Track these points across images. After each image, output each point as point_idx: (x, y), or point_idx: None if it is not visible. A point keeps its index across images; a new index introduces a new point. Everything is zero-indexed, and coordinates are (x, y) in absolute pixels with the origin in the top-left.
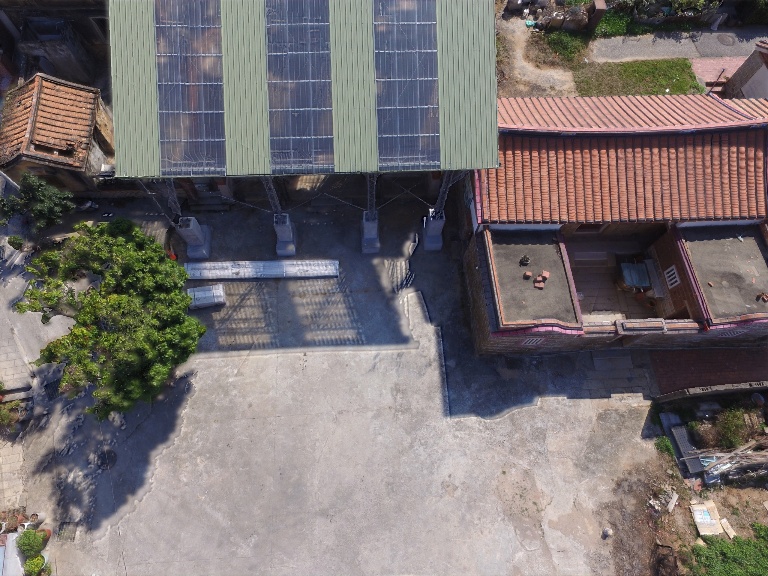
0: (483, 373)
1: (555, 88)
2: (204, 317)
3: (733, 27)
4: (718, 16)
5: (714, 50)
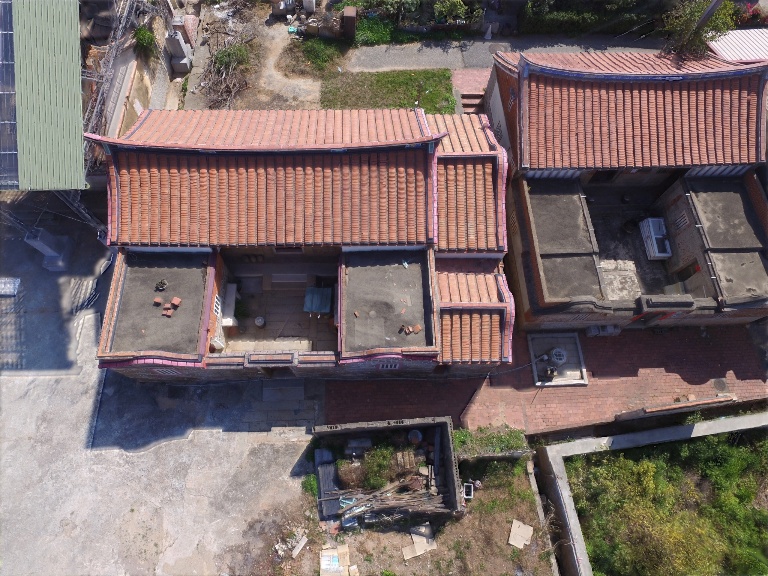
0: (140, 402)
1: (297, 99)
2: None
3: (509, 36)
4: (489, 25)
5: (481, 60)
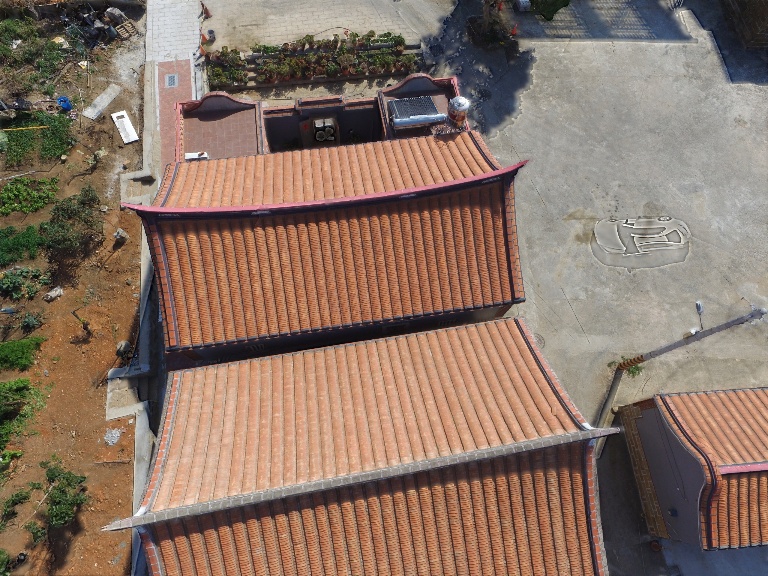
0: (751, 59)
1: None
2: (530, 17)
3: None
4: None
5: None
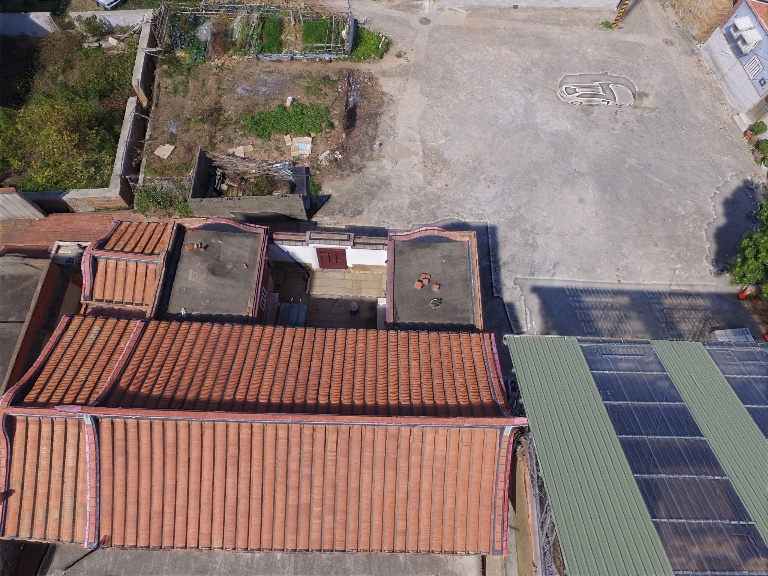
0: None
1: None
2: (725, 322)
3: None
4: None
5: None
